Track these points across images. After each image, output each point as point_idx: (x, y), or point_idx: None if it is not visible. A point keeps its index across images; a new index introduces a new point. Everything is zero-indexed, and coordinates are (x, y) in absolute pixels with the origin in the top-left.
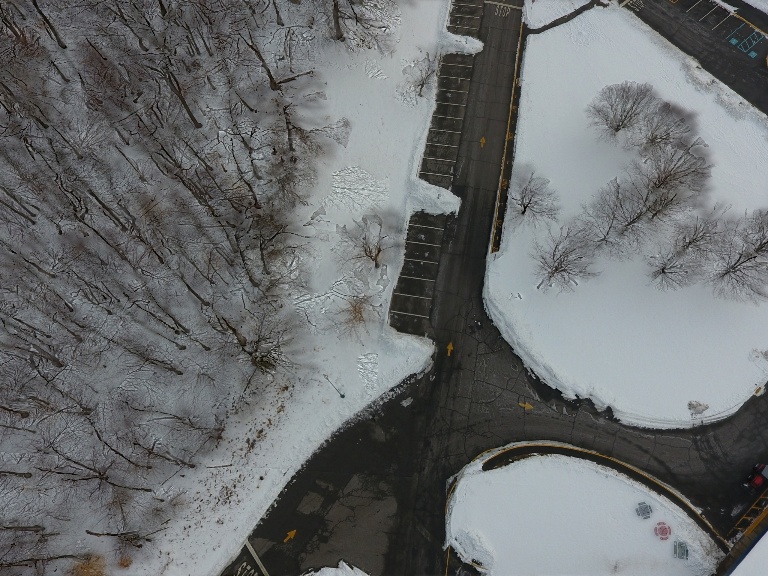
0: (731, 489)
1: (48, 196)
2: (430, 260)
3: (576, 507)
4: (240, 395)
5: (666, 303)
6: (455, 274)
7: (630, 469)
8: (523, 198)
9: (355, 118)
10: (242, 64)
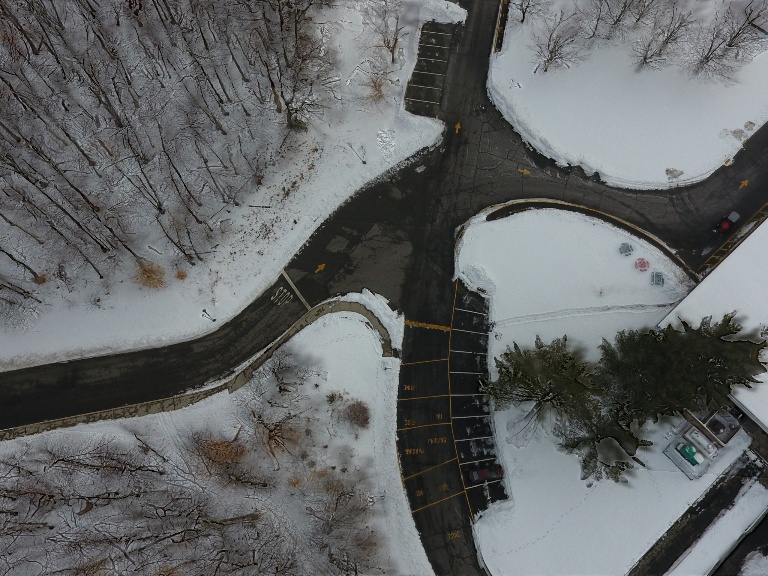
0: (702, 235)
1: None
2: (440, 59)
3: (567, 247)
4: (277, 150)
5: (648, 92)
6: (462, 70)
7: (614, 219)
8: (522, 3)
9: None
10: None
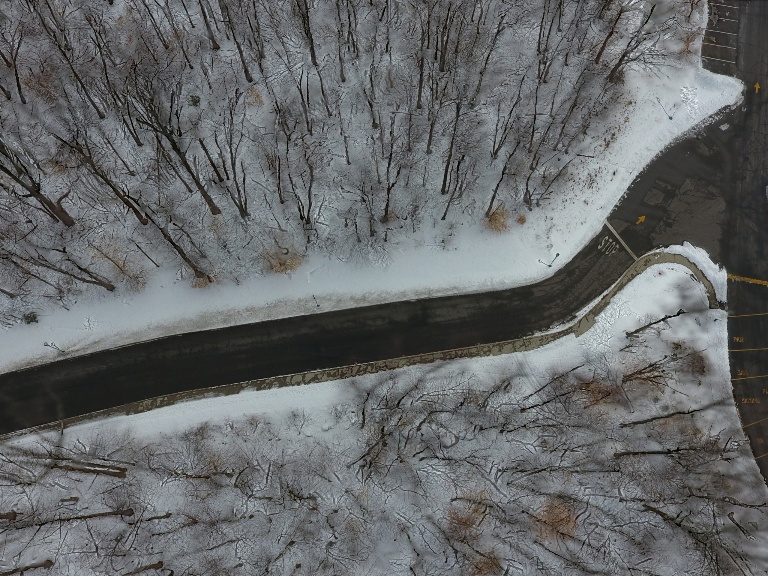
0: None
1: None
2: (731, 18)
3: None
4: (599, 101)
5: None
6: (755, 30)
7: None
8: None
9: None
10: None
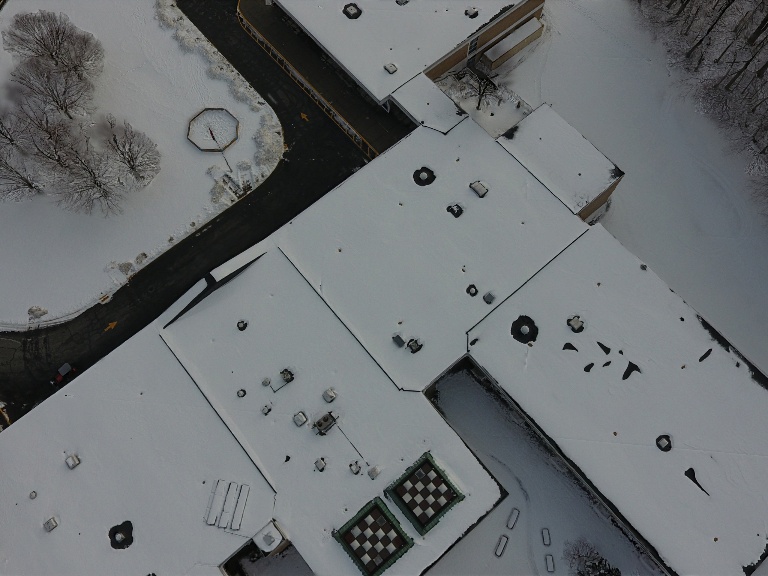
0: (41, 386)
1: None
2: None
3: None
4: None
5: (43, 218)
6: None
7: None
8: None
9: None
10: None
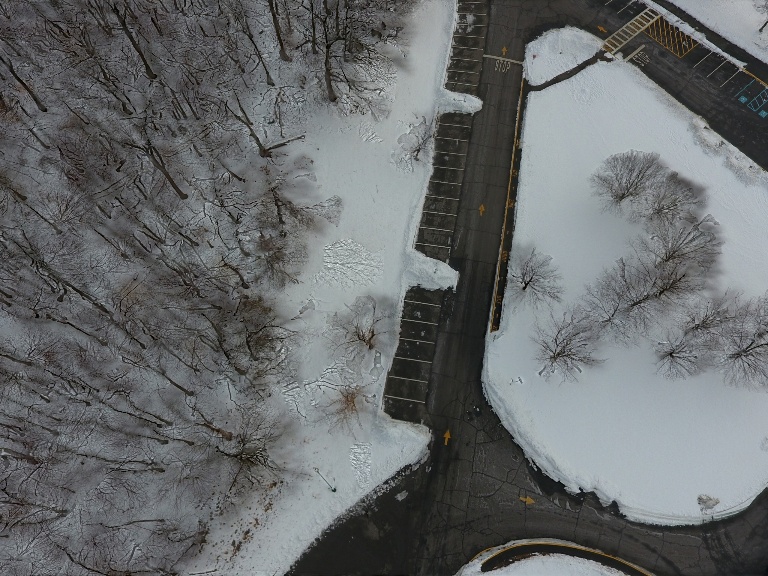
0: None
1: (25, 275)
2: (426, 340)
3: None
4: (225, 495)
5: (674, 387)
6: (453, 355)
7: (637, 570)
8: (524, 275)
9: (348, 186)
10: (230, 128)
